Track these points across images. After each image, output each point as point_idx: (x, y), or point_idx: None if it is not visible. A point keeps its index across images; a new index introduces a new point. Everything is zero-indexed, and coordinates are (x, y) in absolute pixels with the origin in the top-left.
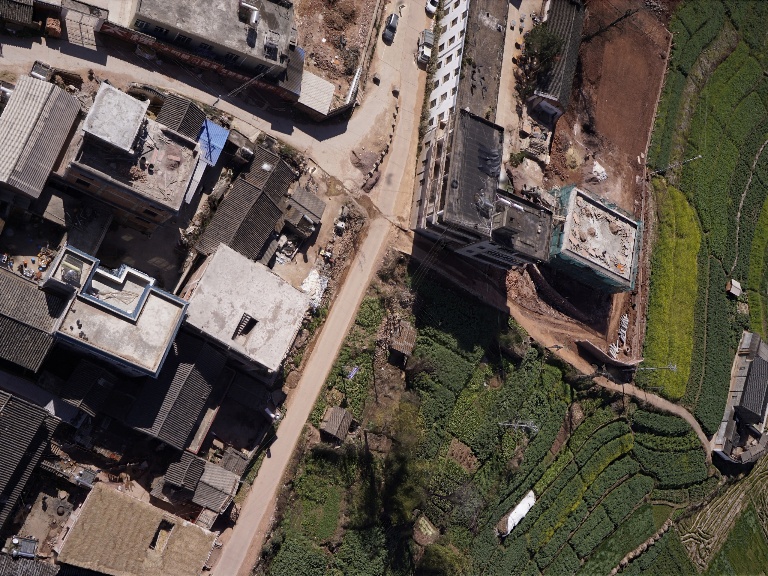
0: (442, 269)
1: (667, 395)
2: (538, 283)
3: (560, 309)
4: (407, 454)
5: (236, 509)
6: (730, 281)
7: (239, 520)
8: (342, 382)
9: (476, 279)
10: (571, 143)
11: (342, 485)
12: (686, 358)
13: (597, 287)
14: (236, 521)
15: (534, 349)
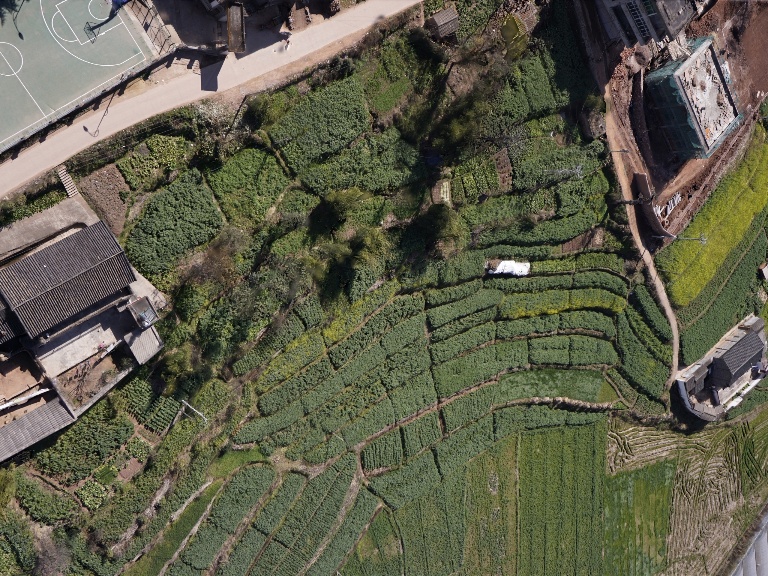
0: (580, 3)
1: (671, 294)
2: (635, 100)
3: (637, 140)
4: (480, 93)
5: (339, 2)
6: (766, 263)
7: (333, 18)
8: (463, 4)
9: (597, 41)
10: (718, 30)
11: (413, 83)
12: (702, 280)
13: (676, 146)
14: (330, 17)
15: (603, 144)
